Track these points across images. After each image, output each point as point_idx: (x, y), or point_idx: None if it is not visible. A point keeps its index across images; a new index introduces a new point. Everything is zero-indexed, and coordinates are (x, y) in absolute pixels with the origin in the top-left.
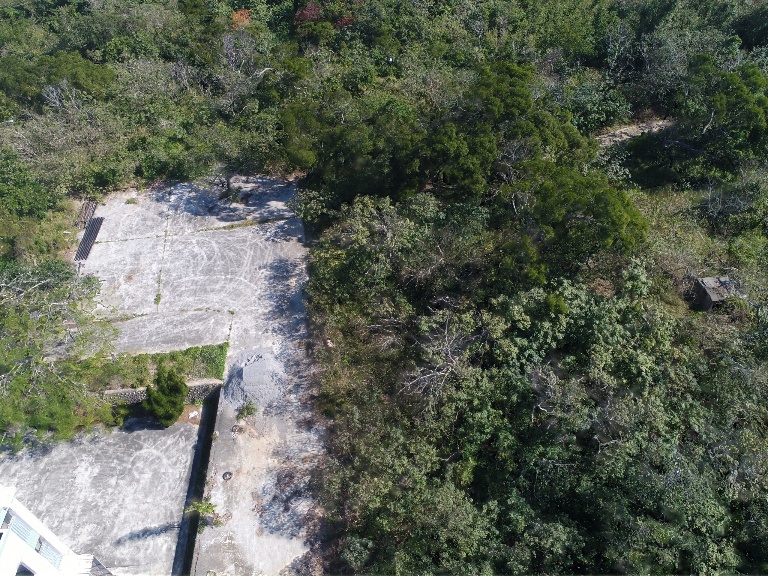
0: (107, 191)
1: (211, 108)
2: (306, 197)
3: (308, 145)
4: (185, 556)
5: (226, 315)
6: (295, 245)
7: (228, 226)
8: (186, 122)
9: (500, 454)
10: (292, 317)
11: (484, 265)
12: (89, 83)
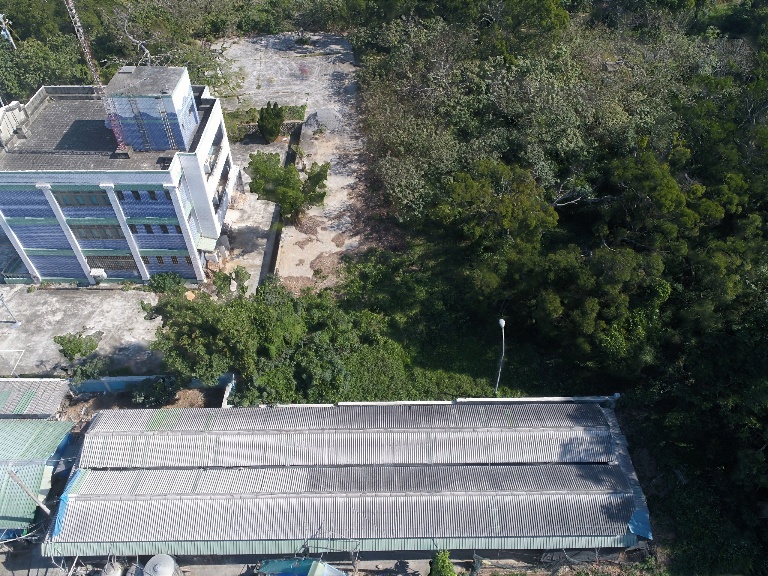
0: (218, 37)
1: None
2: (358, 31)
3: None
4: None
5: (304, 95)
6: (348, 65)
7: (303, 55)
8: (270, 2)
9: (470, 127)
10: (347, 96)
11: None
12: None
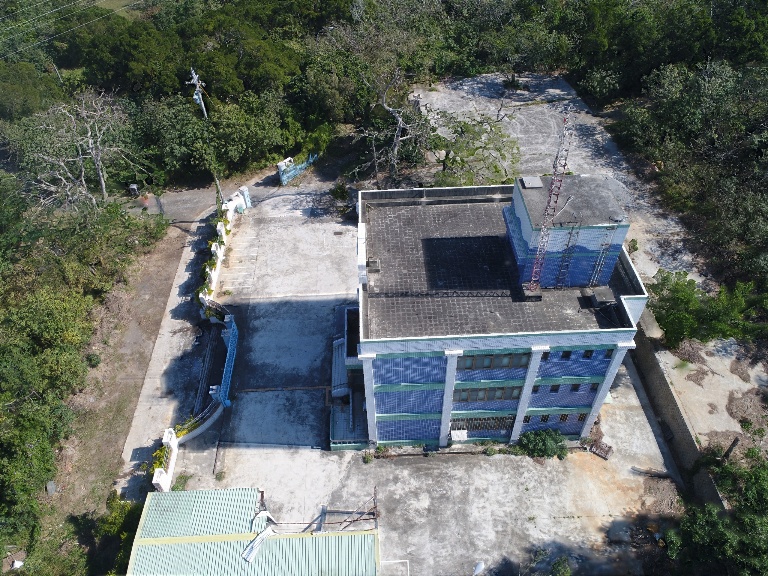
0: None
1: (472, 24)
2: (599, 76)
3: (603, 34)
4: None
5: None
6: (586, 115)
7: None
8: (448, 37)
9: None
10: (612, 157)
11: (754, 122)
12: None
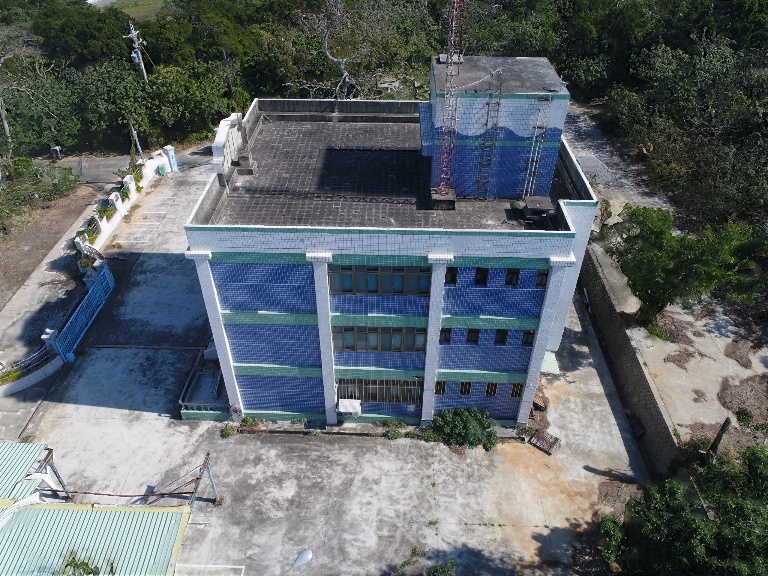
0: None
1: None
2: (585, 64)
3: (590, 20)
4: None
5: None
6: (570, 106)
7: None
8: None
9: None
10: (595, 141)
11: None
12: (346, 7)
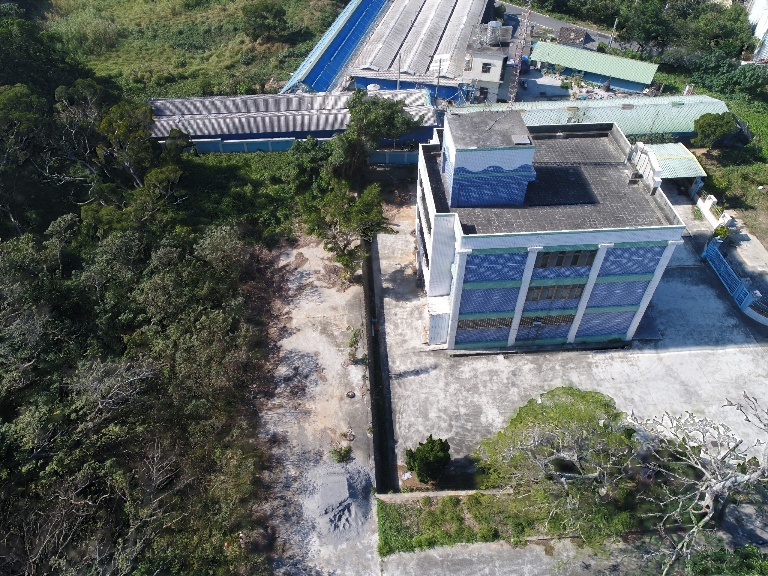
0: None
1: None
2: None
3: None
4: (380, 358)
5: None
6: None
7: None
8: None
9: None
10: None
11: None
12: None
